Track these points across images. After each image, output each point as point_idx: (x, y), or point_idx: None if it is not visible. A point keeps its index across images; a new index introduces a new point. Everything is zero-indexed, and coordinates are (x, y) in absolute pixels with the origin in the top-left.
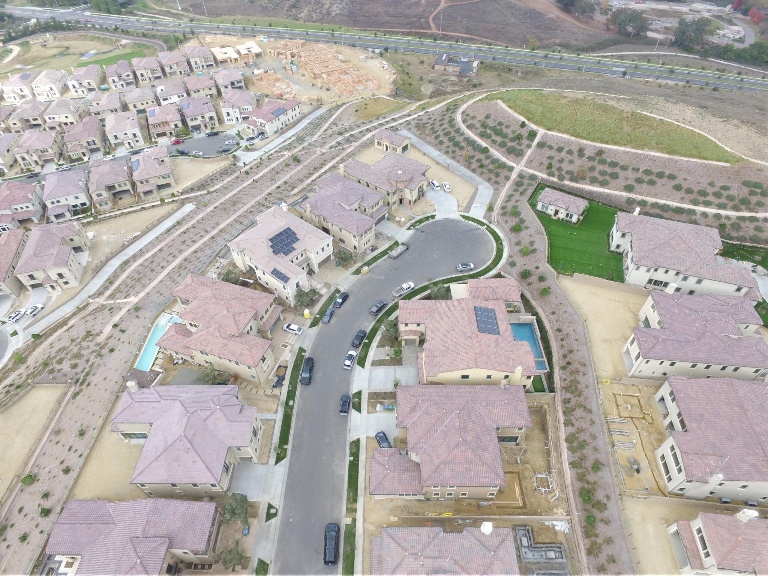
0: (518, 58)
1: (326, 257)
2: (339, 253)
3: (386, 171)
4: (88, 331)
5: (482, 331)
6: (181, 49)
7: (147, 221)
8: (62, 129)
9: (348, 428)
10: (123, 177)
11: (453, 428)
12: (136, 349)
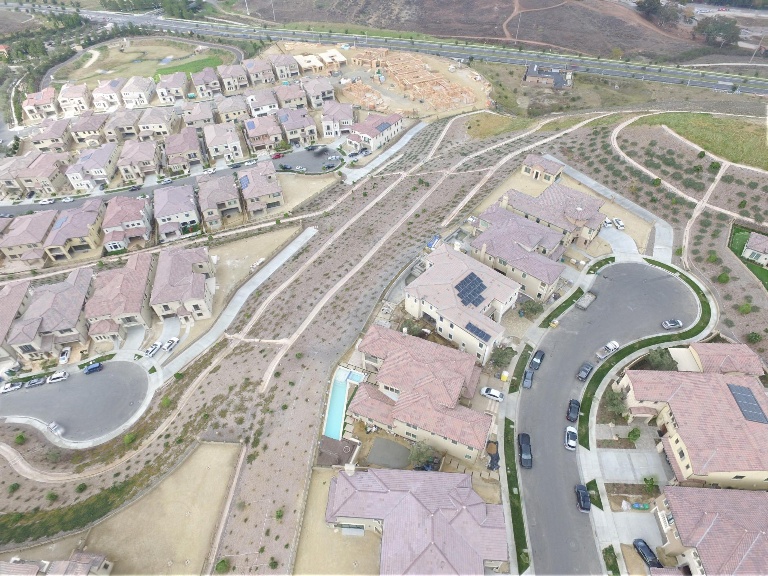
0: (612, 70)
1: (510, 306)
2: (528, 303)
3: (559, 206)
4: (247, 378)
5: (749, 419)
6: (262, 56)
7: (270, 246)
8: (155, 138)
9: (593, 530)
10: (233, 194)
11: (766, 556)
12: (320, 411)
